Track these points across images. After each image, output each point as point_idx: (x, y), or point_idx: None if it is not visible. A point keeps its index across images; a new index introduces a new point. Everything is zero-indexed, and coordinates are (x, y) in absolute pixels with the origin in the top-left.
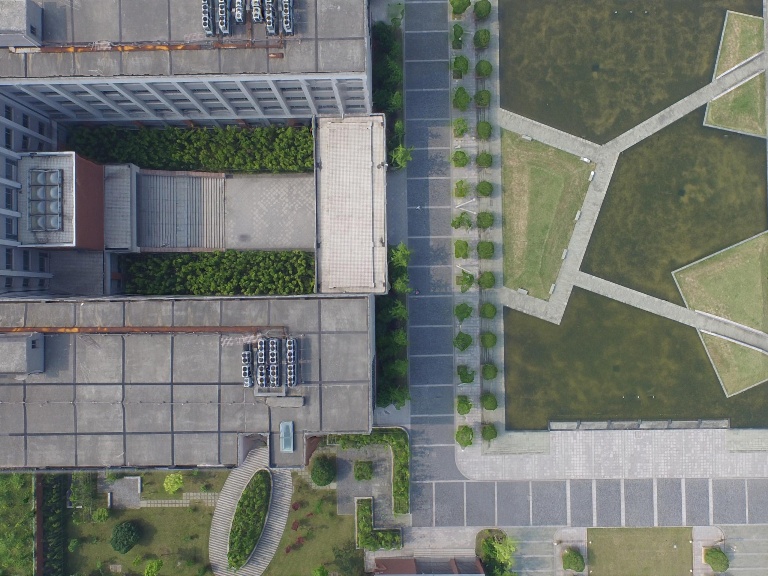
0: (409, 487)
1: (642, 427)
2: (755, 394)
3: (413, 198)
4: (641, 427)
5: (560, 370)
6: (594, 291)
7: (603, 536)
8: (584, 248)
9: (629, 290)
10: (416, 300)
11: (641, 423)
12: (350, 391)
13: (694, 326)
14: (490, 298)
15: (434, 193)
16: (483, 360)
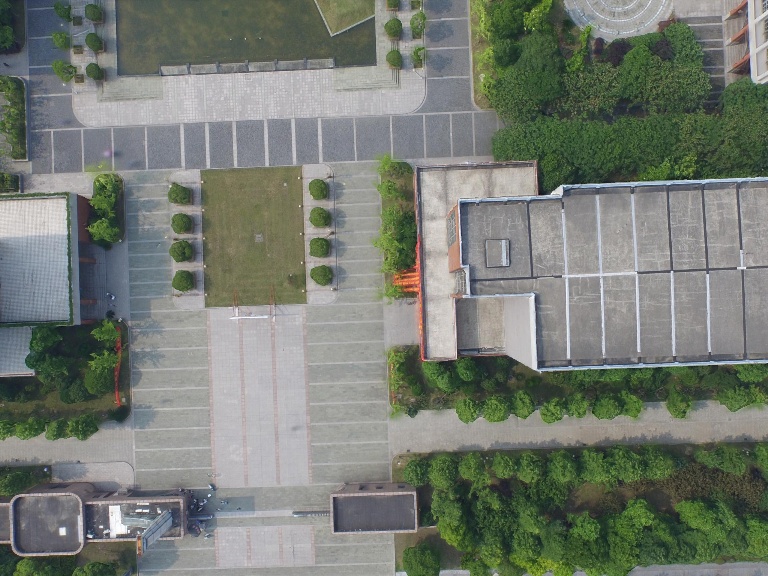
0: (27, 135)
1: (251, 70)
2: (360, 33)
3: None
4: (250, 70)
5: (171, 17)
6: None
7: (216, 177)
8: None
9: None
10: None
11: (249, 64)
12: None
13: None
14: None
15: None
16: None
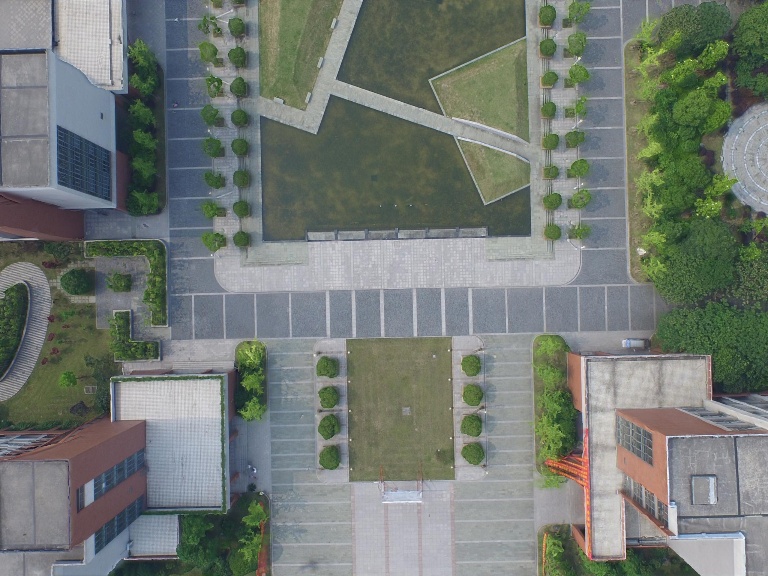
0: (167, 299)
1: (401, 237)
2: (514, 202)
3: (171, 10)
4: (400, 237)
5: (318, 180)
6: (351, 100)
7: (362, 347)
8: (341, 57)
9: (386, 98)
10: (175, 113)
11: (399, 232)
12: (30, 146)
13: (451, 134)
14: (247, 108)
15: (192, 5)
16: None
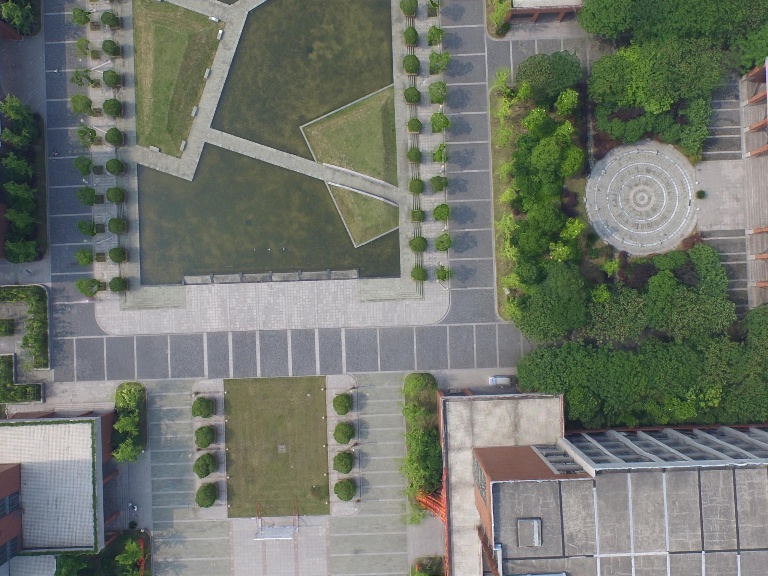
0: (50, 343)
1: (275, 279)
2: (384, 244)
3: (51, 62)
4: (274, 279)
5: (194, 225)
6: (225, 147)
7: (239, 386)
8: (215, 105)
9: (259, 145)
10: (55, 161)
11: (272, 275)
12: None
13: (322, 179)
14: (124, 156)
15: (71, 56)
16: (119, 217)
